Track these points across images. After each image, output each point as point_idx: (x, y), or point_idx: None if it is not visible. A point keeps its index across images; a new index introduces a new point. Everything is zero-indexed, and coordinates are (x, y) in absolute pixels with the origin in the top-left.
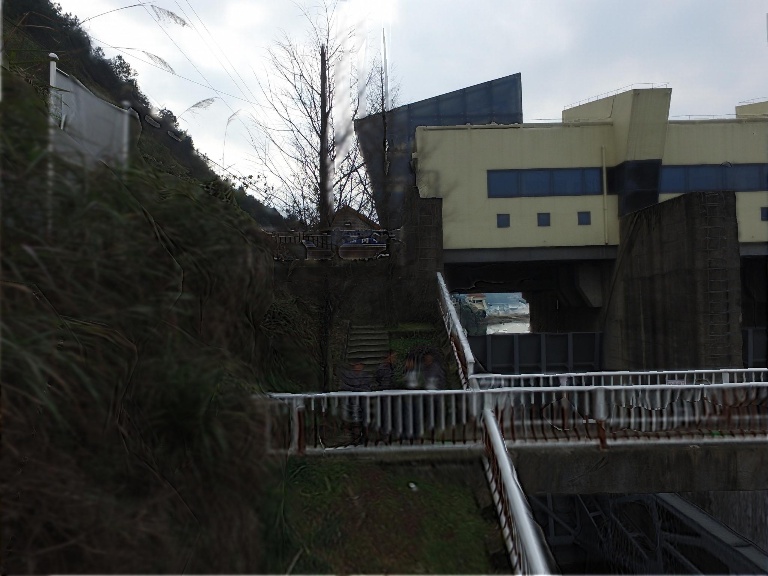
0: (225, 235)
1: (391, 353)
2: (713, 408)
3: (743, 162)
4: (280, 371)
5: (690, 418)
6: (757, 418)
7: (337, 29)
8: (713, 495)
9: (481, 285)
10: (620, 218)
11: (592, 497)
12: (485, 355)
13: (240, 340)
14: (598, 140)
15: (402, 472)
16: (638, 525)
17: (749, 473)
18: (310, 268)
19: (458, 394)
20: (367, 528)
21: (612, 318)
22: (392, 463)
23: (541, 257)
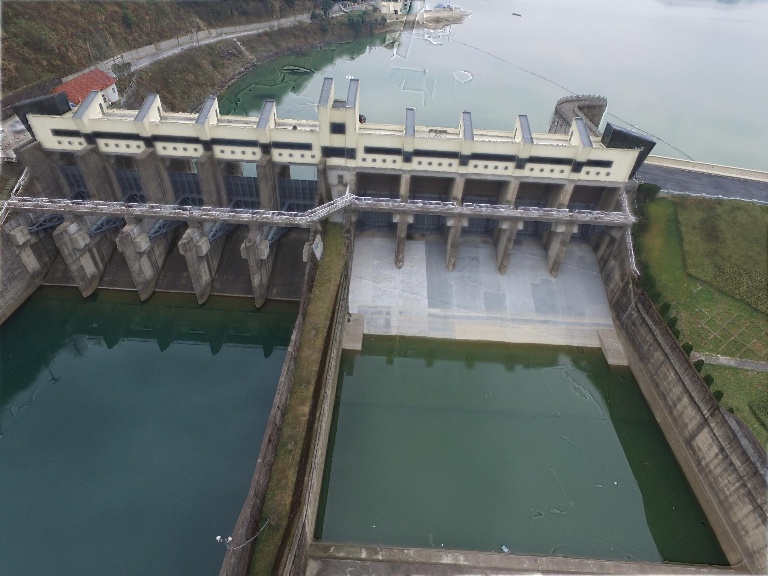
0: None
1: None
2: None
3: None
4: None
5: None
6: None
7: None
8: None
9: None
10: None
11: None
12: None
13: None
14: None
15: None
16: None
17: None
18: None
19: (2, 201)
20: None
21: None
22: None
23: None
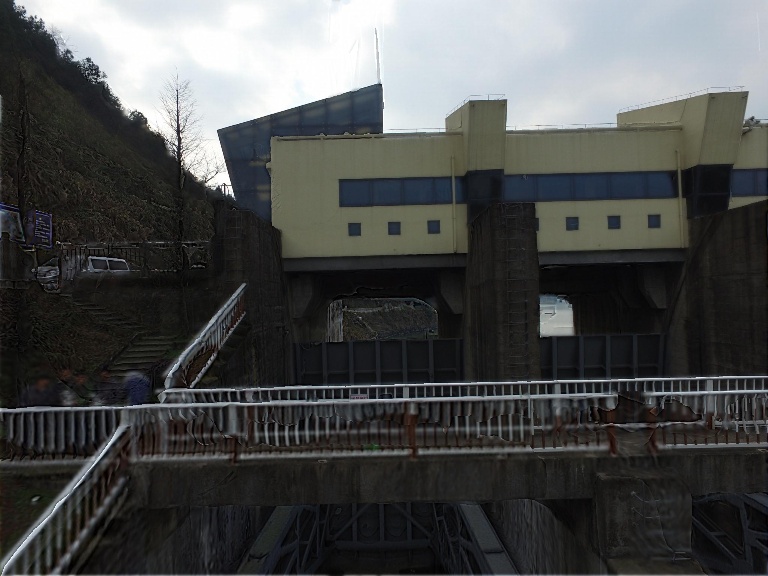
0: None
1: None
2: (344, 424)
3: (591, 171)
4: None
5: (321, 433)
6: (386, 433)
7: (330, 28)
8: None
9: (363, 291)
10: (467, 227)
11: None
12: (347, 361)
13: None
14: (448, 150)
15: (38, 486)
16: None
17: (371, 486)
18: (118, 279)
19: (98, 411)
20: None
21: (466, 325)
22: (30, 477)
23: (393, 265)
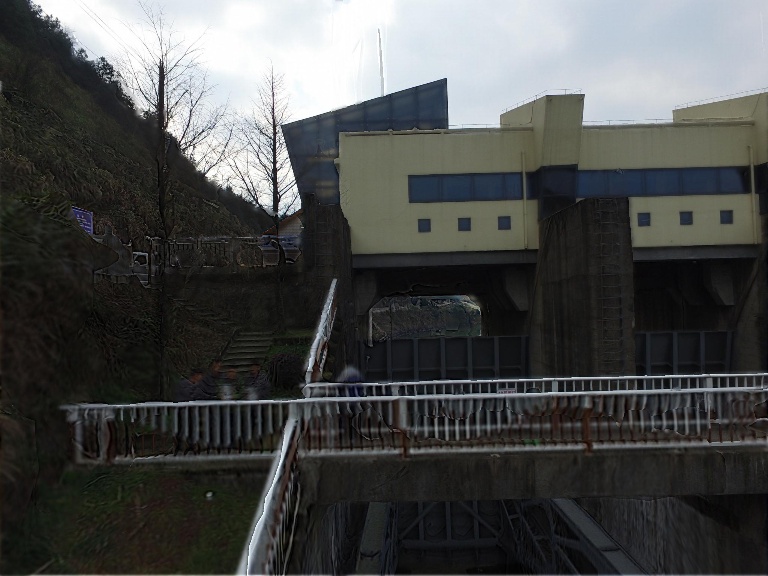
0: (15, 250)
1: (266, 360)
2: (515, 418)
3: (662, 167)
4: (119, 380)
5: (492, 427)
6: (559, 427)
7: (333, 29)
8: (602, 499)
9: (418, 288)
10: (539, 223)
11: (513, 500)
12: (412, 359)
13: (34, 353)
14: (518, 145)
15: (206, 481)
16: (544, 528)
17: (547, 481)
18: (208, 275)
19: (264, 404)
20: (139, 538)
21: (535, 322)
22: (197, 472)
23: (462, 262)
